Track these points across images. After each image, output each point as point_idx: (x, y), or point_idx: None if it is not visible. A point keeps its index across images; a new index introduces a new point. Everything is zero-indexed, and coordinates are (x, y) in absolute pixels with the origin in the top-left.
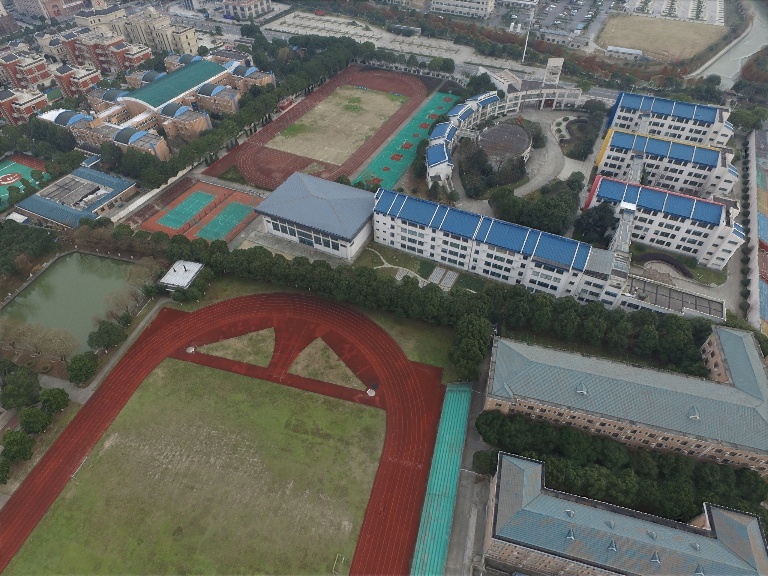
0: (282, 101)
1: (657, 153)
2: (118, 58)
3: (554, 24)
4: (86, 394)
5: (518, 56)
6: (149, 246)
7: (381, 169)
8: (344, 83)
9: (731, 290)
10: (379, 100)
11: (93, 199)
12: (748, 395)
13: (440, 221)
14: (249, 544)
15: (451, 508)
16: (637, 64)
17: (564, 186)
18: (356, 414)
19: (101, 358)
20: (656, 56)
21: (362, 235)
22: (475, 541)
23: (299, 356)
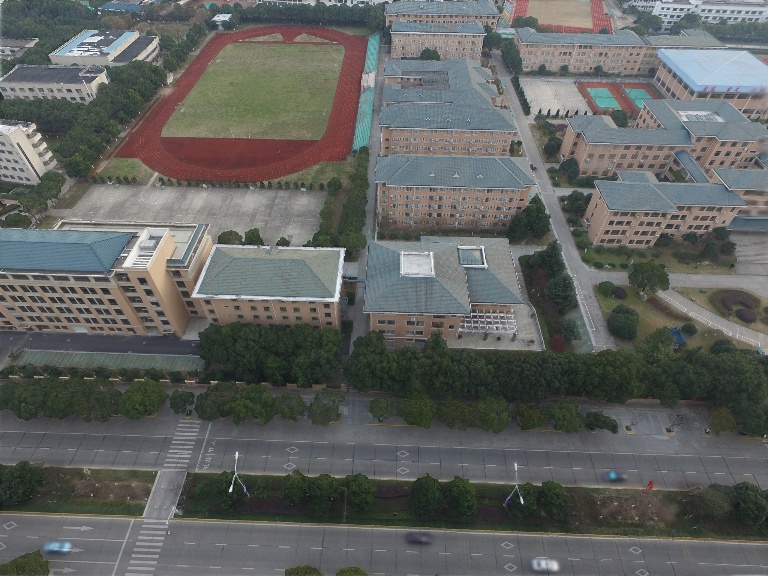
0: None
1: None
2: None
3: None
4: (196, 53)
5: None
6: None
7: None
8: None
9: None
10: None
11: (148, 2)
12: None
13: None
14: None
15: None
16: None
17: None
18: None
19: None
20: None
21: (313, 4)
22: None
23: (296, 38)
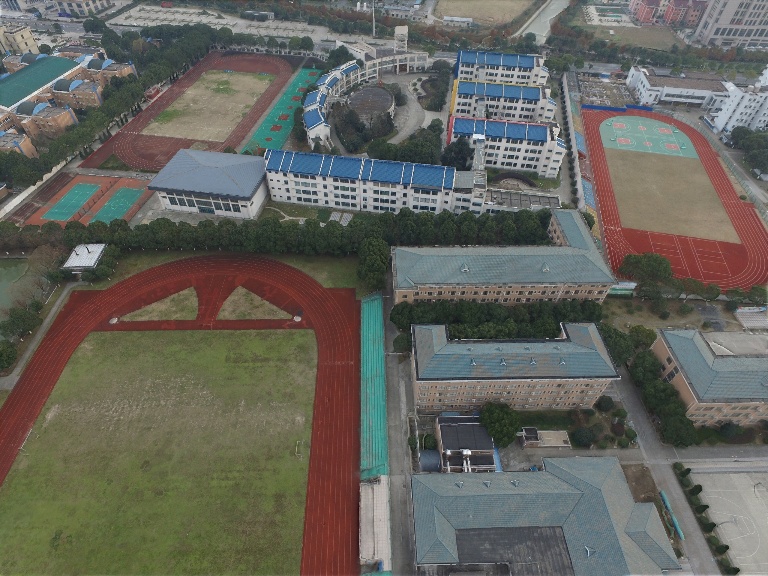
0: (148, 90)
1: (495, 95)
2: None
3: (395, 1)
4: (11, 380)
5: (369, 31)
6: (42, 237)
7: (264, 140)
8: (209, 68)
9: (565, 191)
10: (247, 80)
11: None
12: (580, 249)
13: (328, 169)
14: (216, 455)
15: (383, 383)
16: (470, 30)
17: (427, 130)
18: (288, 338)
19: (18, 347)
20: (484, 22)
21: (259, 196)
22: (407, 403)
23: (224, 304)
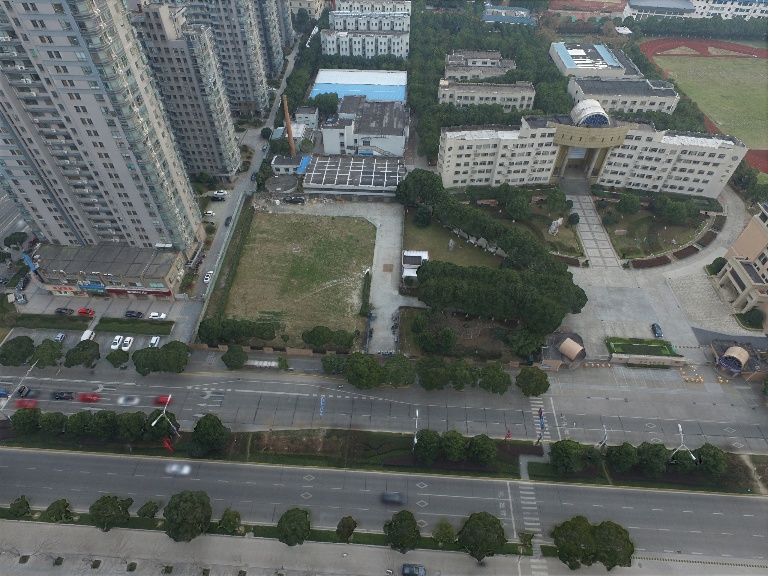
0: None
1: None
2: None
3: None
4: None
5: None
6: (593, 23)
7: None
8: None
9: None
10: None
11: None
12: None
13: None
14: (766, 84)
15: None
16: None
17: None
18: (758, 60)
19: None
20: None
21: None
22: None
23: None
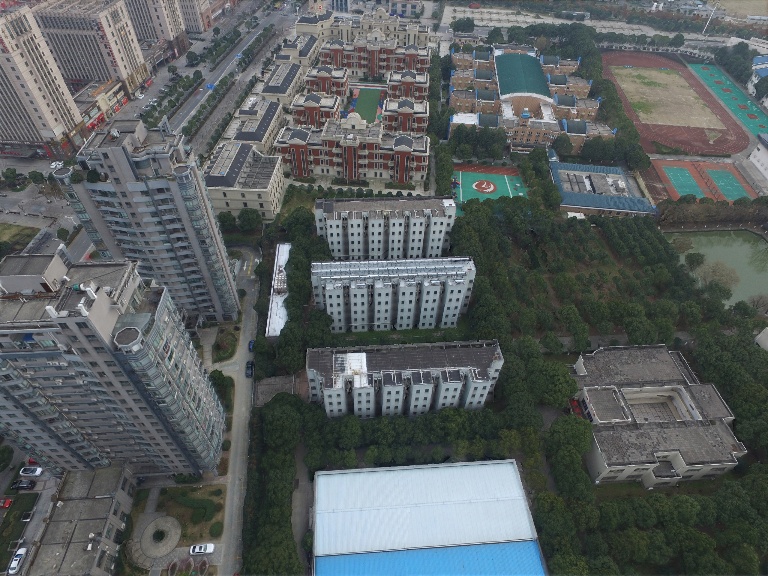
0: None
1: None
2: (412, 61)
3: None
4: None
5: (700, 29)
6: (749, 210)
7: (760, 127)
8: (606, 64)
9: None
10: (659, 75)
11: None
12: None
13: None
14: None
15: None
16: None
17: None
18: None
19: None
20: None
21: None
22: None
23: None
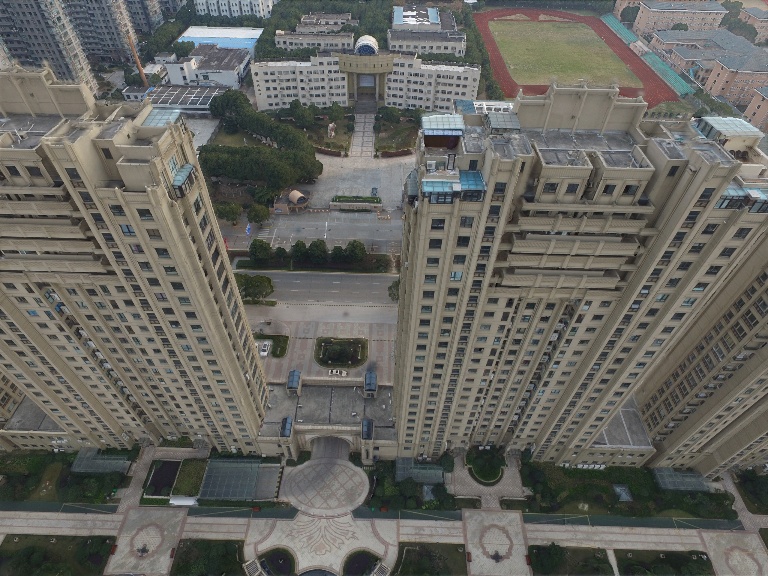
0: None
1: None
2: None
3: None
4: None
5: None
6: None
7: None
8: None
9: None
10: None
11: None
12: None
13: None
14: None
15: None
16: None
17: None
18: None
19: None
20: None
21: None
22: None
23: (539, 17)
